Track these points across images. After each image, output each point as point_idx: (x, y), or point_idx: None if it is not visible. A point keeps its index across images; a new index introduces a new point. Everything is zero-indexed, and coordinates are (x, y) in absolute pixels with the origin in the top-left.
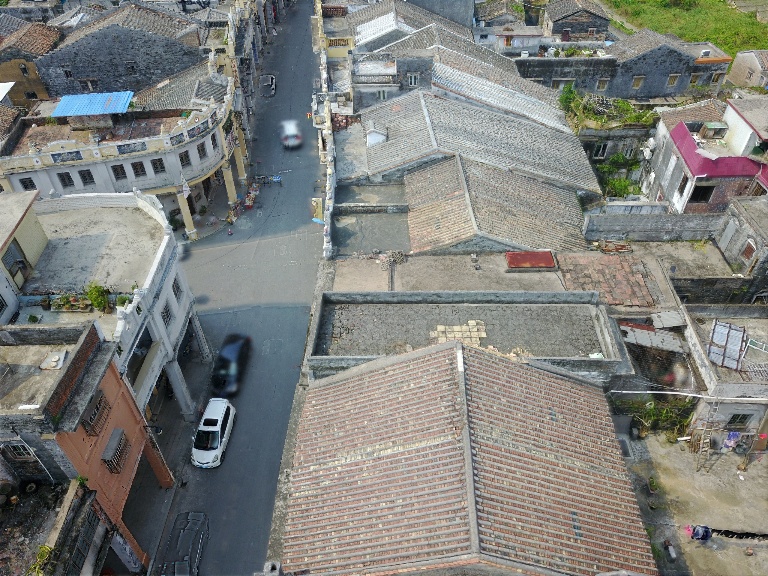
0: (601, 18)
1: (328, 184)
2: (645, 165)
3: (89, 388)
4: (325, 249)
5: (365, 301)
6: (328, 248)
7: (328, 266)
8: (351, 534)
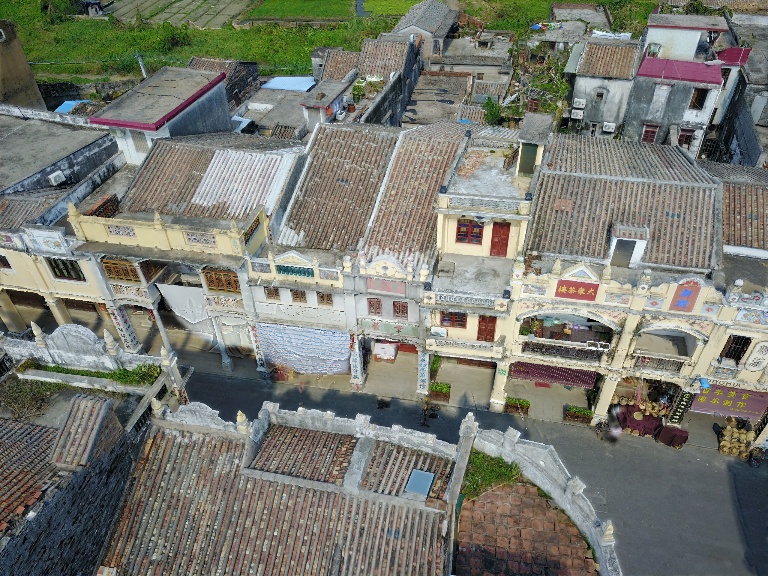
0: (251, 64)
1: None
2: (569, 127)
3: None
4: None
5: None
6: None
7: None
8: None
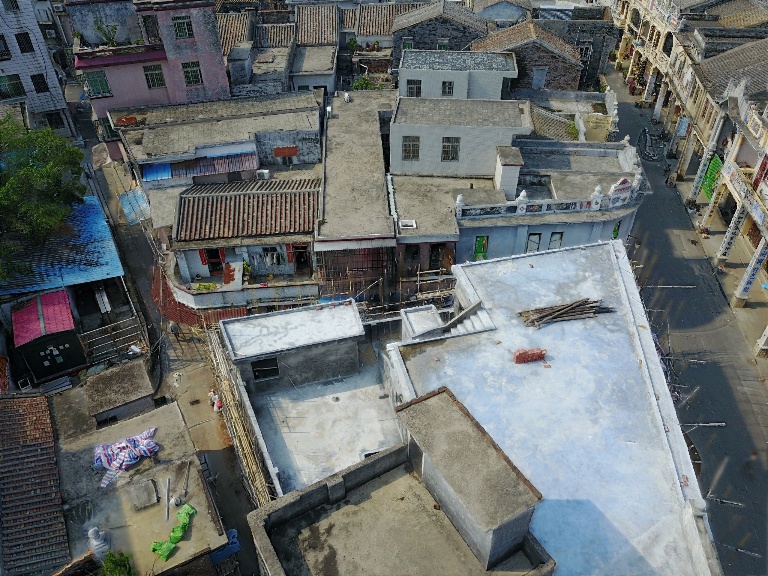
0: None
1: (668, 2)
2: None
3: (614, 29)
4: (681, 23)
5: (720, 35)
6: (684, 22)
7: (681, 34)
8: (763, 81)
